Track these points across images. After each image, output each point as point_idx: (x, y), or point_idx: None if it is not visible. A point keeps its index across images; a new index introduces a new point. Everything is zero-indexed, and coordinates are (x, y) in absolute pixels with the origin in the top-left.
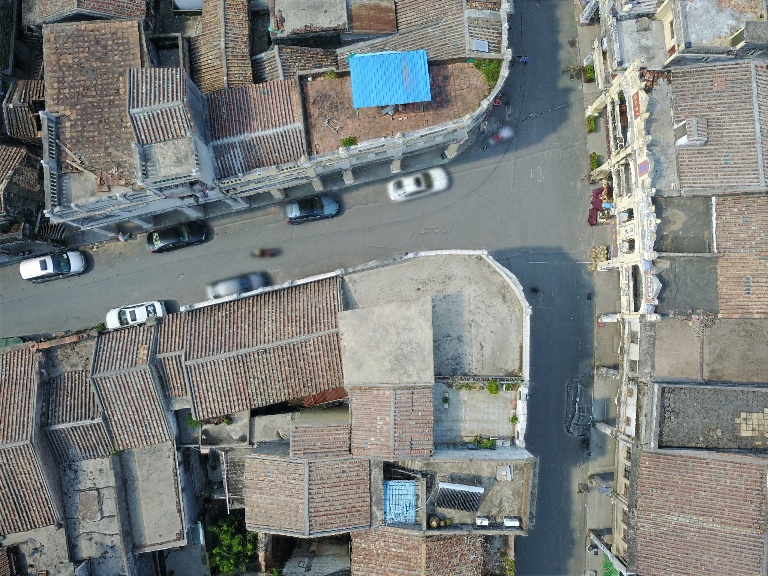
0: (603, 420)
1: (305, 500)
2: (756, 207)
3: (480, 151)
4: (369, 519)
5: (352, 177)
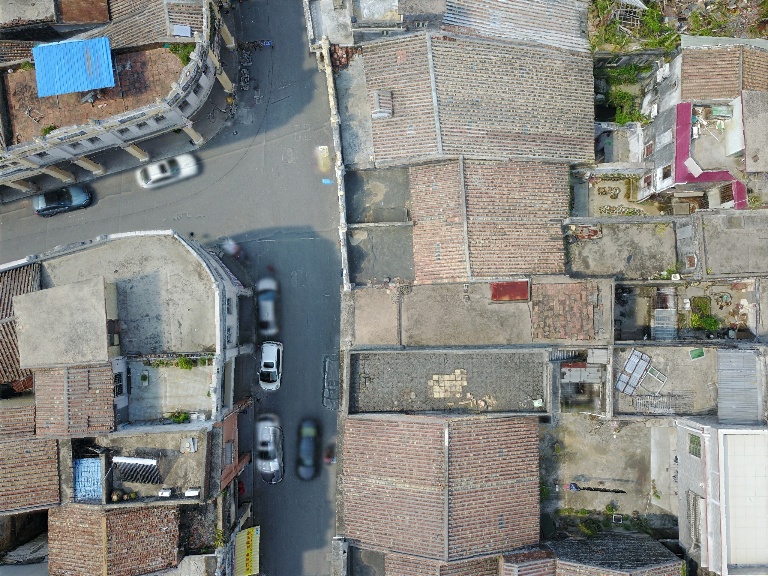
0: None
1: None
2: (442, 175)
3: (231, 136)
4: (57, 497)
5: (97, 167)
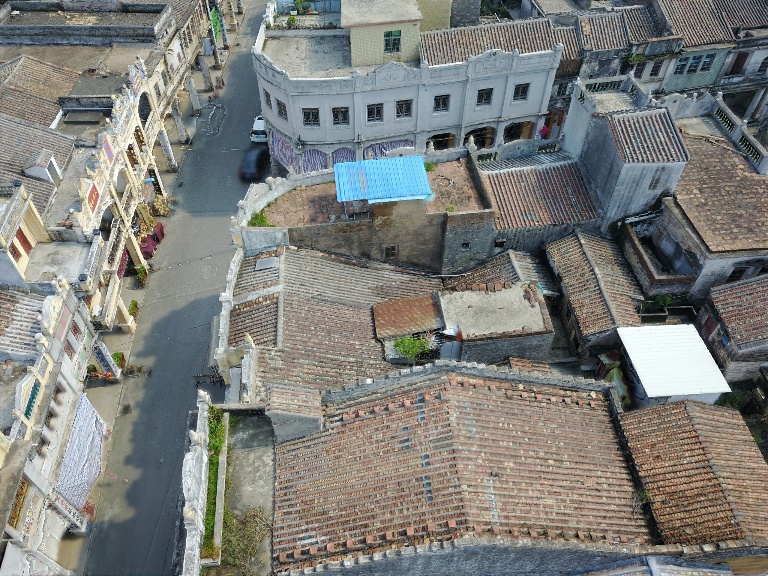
0: (192, 116)
1: None
2: None
3: None
4: None
5: None
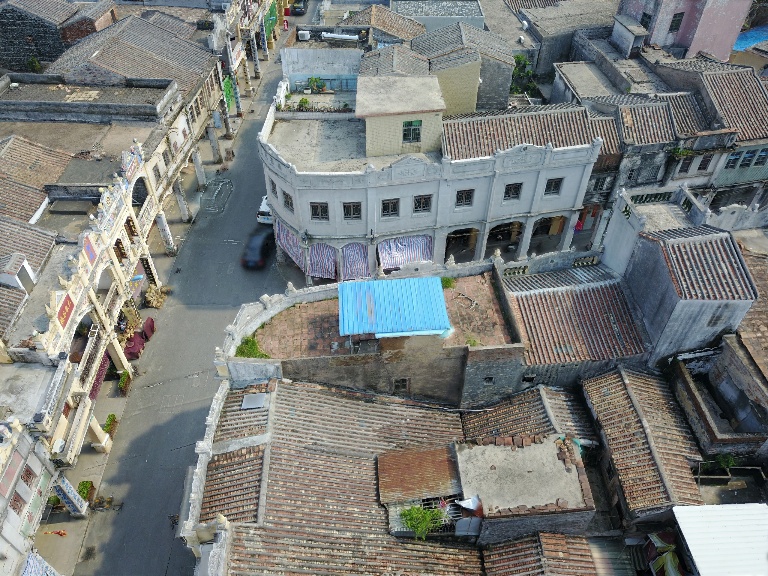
0: (198, 191)
1: None
2: None
3: None
4: None
5: None
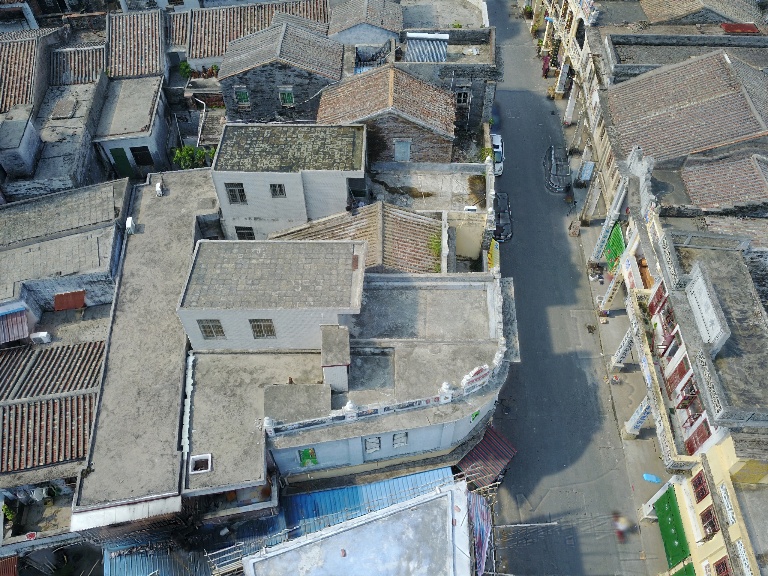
0: None
1: (279, 40)
2: None
3: None
4: (339, 74)
5: None
